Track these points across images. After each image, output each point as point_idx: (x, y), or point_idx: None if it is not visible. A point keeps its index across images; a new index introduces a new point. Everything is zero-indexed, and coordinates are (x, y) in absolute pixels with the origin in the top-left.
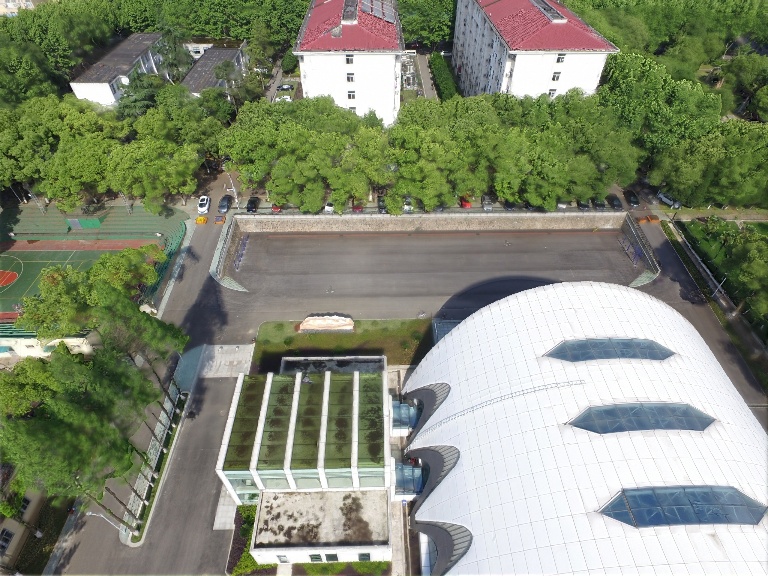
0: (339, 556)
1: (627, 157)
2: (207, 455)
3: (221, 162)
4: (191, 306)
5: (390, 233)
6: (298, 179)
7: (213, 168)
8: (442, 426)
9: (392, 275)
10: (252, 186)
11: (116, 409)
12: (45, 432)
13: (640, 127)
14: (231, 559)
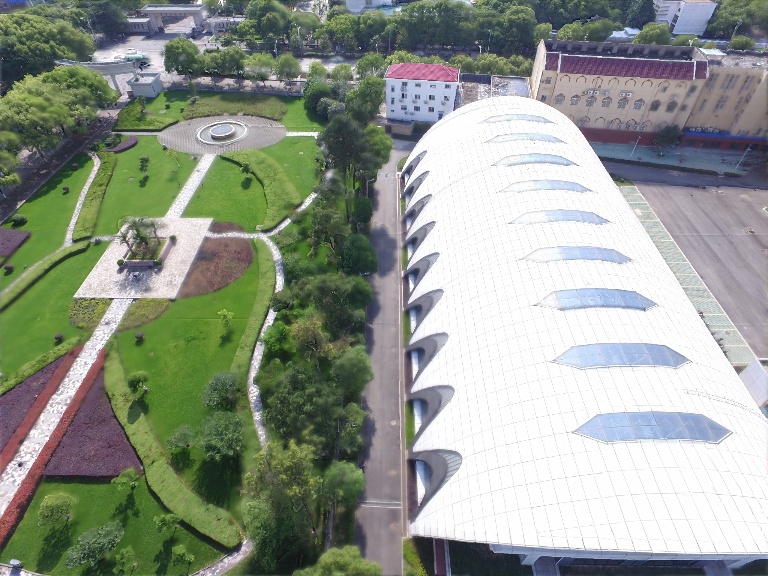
0: None
1: None
2: None
3: None
4: None
5: None
6: None
7: None
8: None
9: None
10: None
11: None
12: None
13: None
14: None
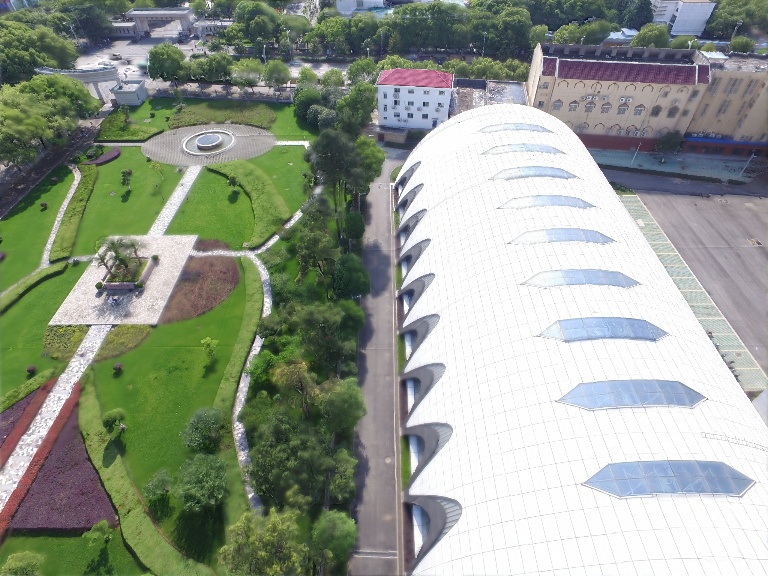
0: None
1: None
2: None
3: None
4: None
5: None
6: None
7: None
8: None
9: None
10: None
11: None
12: None
13: None
14: None
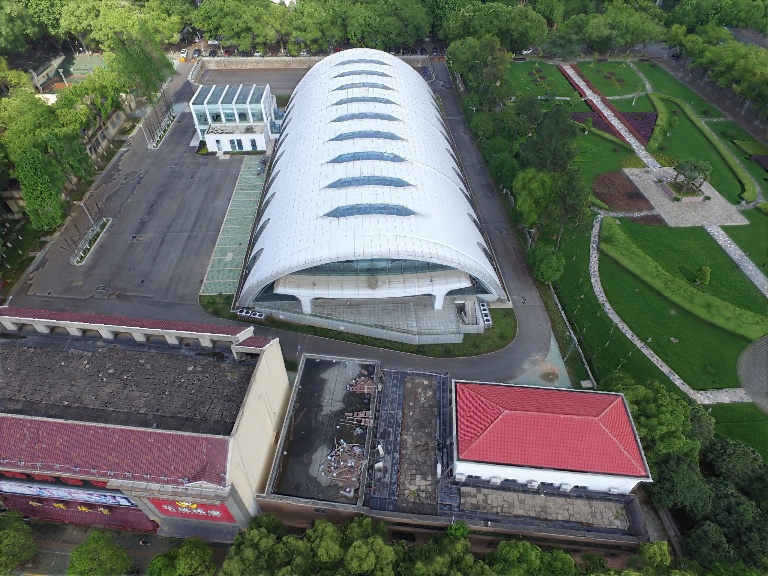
0: (243, 143)
1: (419, 18)
2: (187, 130)
3: (194, 39)
4: (178, 90)
5: (293, 69)
6: (236, 29)
7: (189, 41)
8: (292, 102)
9: (289, 82)
10: (211, 39)
11: (148, 68)
12: (126, 51)
13: (436, 8)
14: (197, 151)
